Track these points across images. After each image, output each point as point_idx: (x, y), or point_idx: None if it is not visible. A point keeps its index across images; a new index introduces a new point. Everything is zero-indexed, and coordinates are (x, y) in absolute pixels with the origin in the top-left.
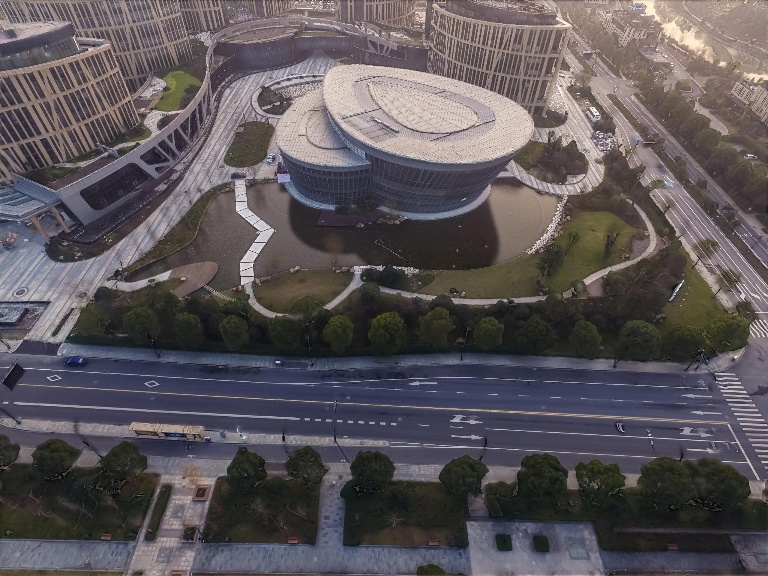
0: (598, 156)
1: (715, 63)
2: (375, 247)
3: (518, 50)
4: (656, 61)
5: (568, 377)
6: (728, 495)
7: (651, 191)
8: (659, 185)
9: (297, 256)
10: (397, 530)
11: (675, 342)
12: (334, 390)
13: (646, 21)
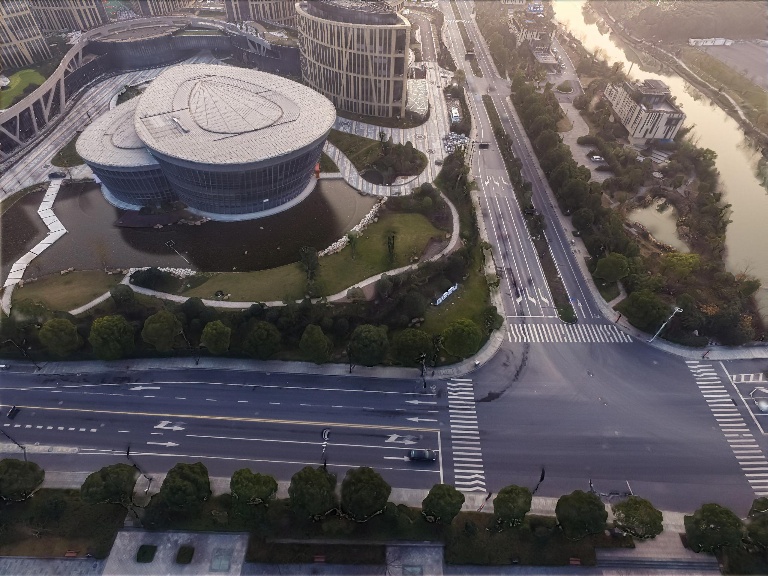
0: (441, 157)
1: (602, 64)
2: (163, 248)
3: (363, 50)
4: (544, 62)
5: (298, 382)
6: (360, 506)
7: (477, 193)
8: (472, 187)
9: (78, 257)
10: (40, 540)
11: (400, 347)
12: (50, 395)
13: (540, 22)
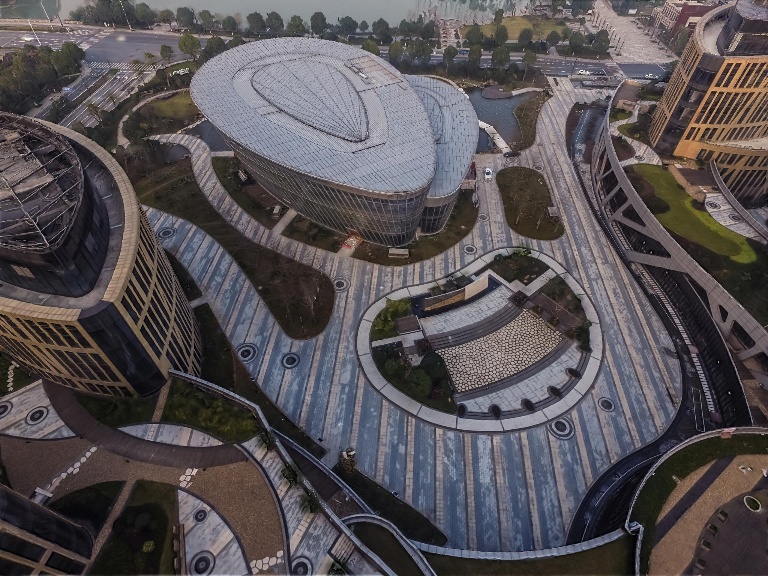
0: None
1: None
2: None
3: None
4: None
5: None
6: None
7: None
8: None
9: None
10: None
11: None
12: None
13: None
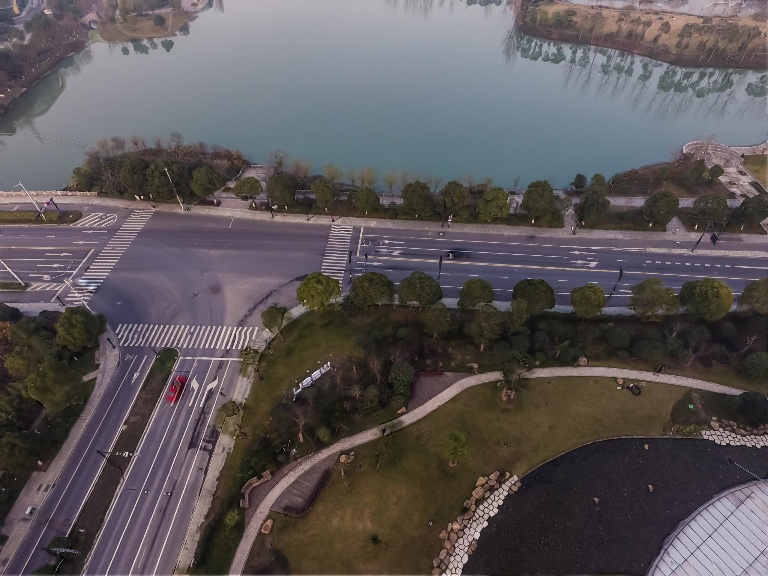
0: None
1: None
2: None
3: None
4: None
5: None
6: None
7: None
8: None
9: None
10: None
11: None
12: None
13: None
